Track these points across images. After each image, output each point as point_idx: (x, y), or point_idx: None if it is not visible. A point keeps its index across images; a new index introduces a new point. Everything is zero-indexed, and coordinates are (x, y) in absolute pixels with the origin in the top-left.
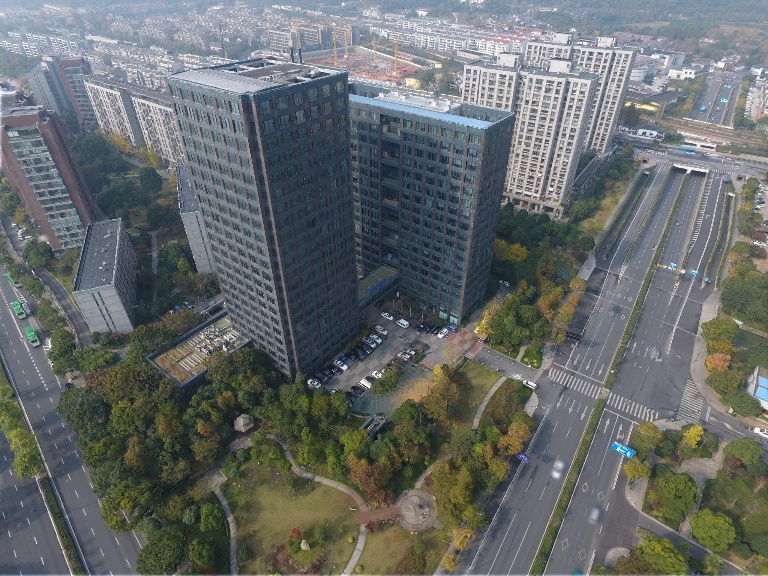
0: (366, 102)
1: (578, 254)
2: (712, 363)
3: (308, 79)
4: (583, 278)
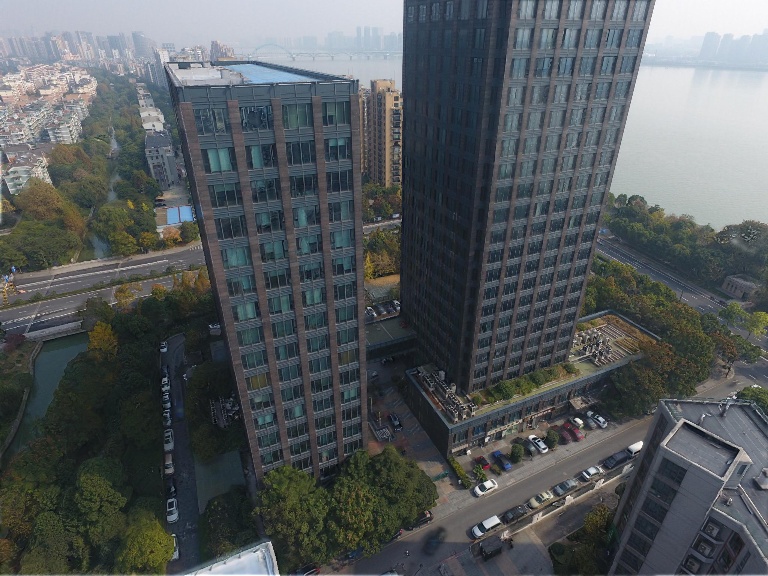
0: (287, 77)
1: (13, 342)
2: (176, 233)
3: None
4: (76, 324)
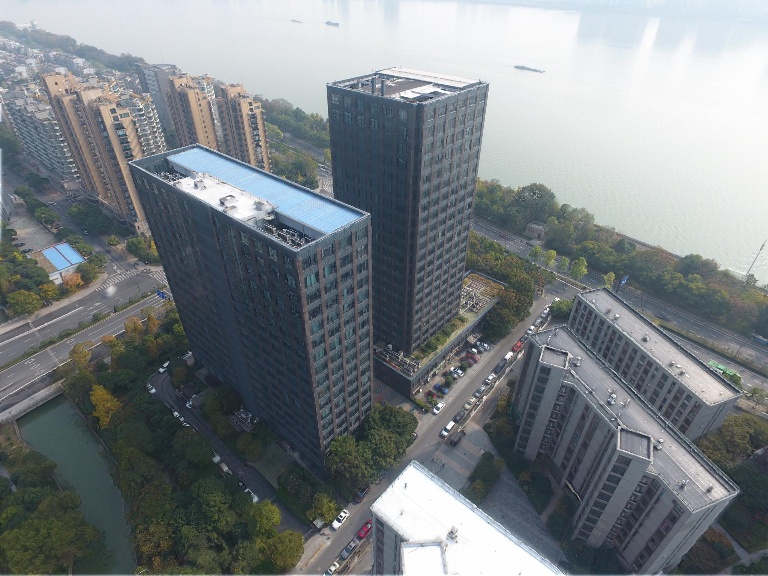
0: (294, 195)
1: None
2: (78, 278)
3: (362, 81)
4: (41, 394)
